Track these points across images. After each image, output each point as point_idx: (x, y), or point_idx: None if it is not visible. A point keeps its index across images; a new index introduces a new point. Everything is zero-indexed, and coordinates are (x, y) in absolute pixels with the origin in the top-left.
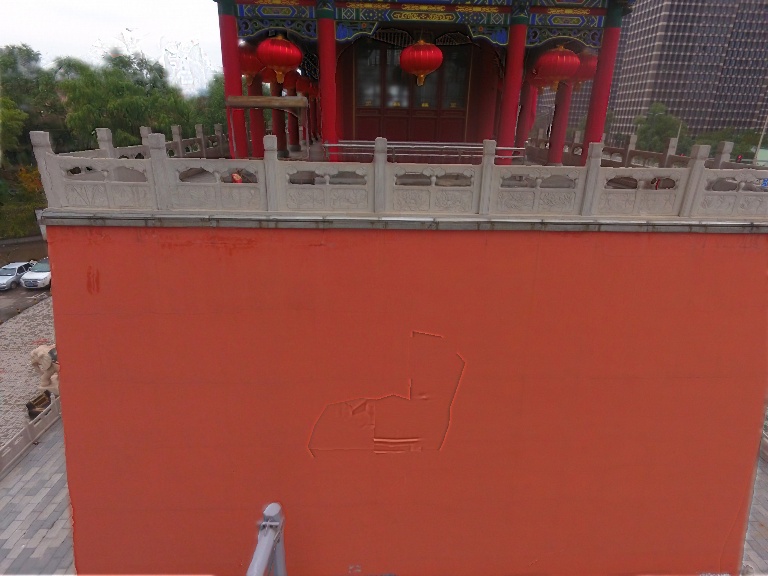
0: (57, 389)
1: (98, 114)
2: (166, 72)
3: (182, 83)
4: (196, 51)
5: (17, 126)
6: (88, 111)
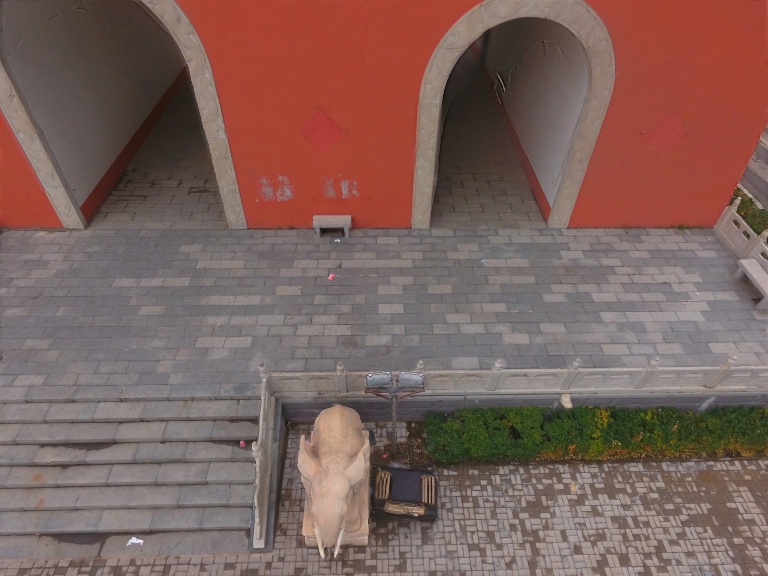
0: (368, 485)
1: None
2: None
3: None
4: None
5: None
6: None
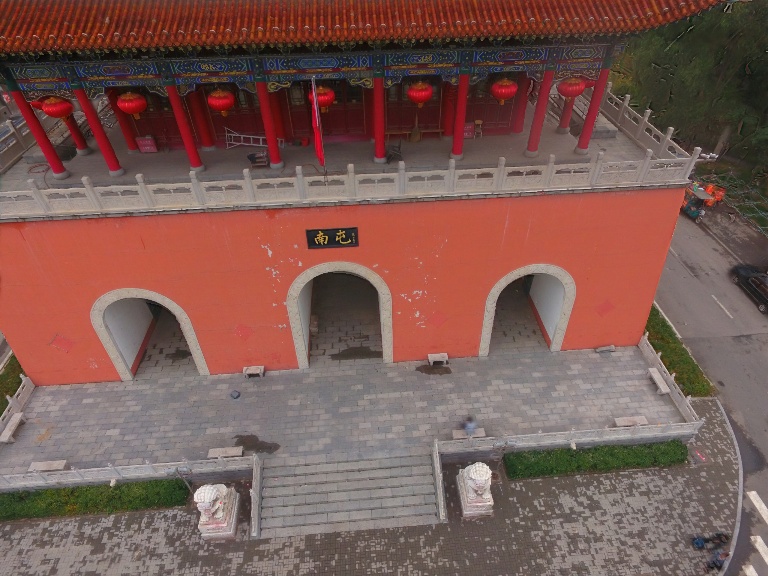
0: None
1: None
2: None
3: None
4: None
5: None
6: None
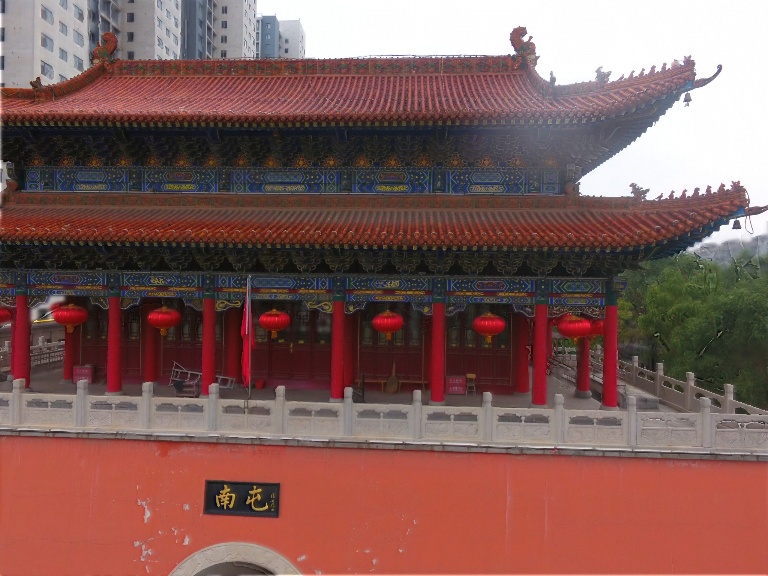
0: None
1: (661, 318)
2: (761, 272)
3: (710, 287)
4: (724, 250)
5: (618, 324)
6: (653, 314)
